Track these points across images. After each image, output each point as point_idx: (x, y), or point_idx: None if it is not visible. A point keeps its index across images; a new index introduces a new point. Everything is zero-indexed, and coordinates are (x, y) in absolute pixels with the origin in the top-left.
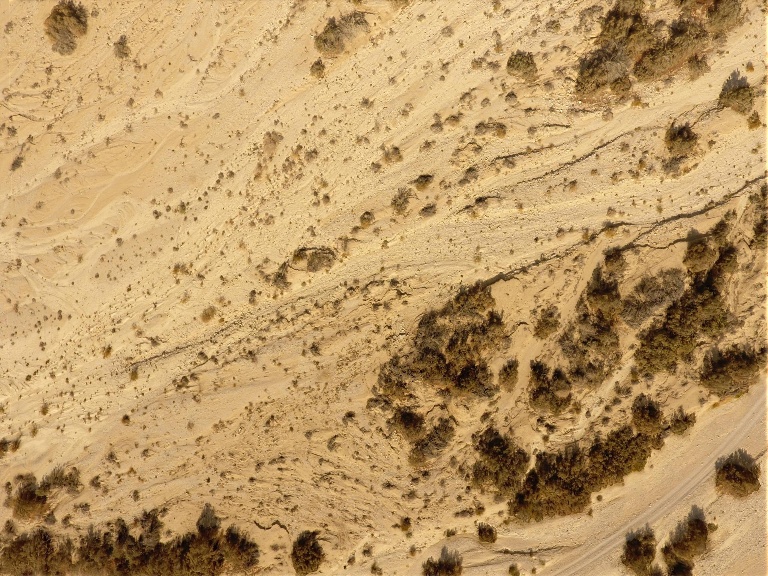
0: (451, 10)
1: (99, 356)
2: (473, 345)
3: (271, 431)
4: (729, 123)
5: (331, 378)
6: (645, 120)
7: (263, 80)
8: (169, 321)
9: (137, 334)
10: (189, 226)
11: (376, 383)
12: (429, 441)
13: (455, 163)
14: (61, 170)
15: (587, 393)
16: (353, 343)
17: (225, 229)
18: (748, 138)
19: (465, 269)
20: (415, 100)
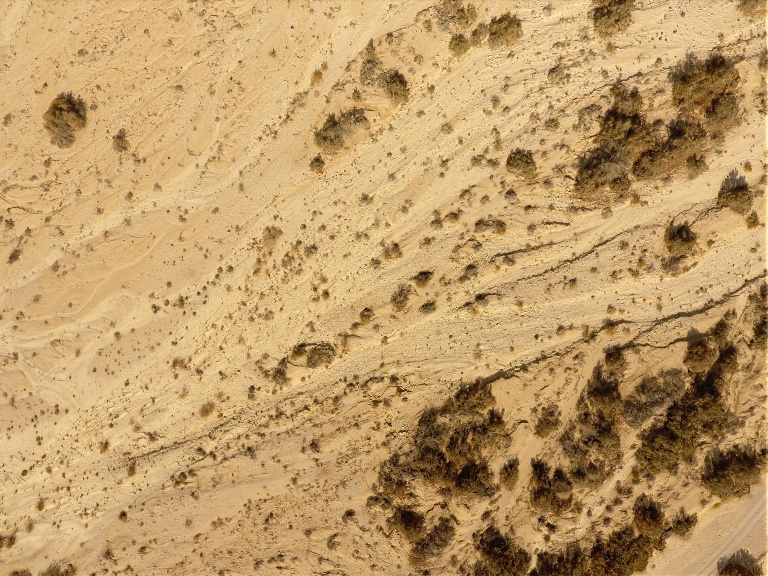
0: (450, 107)
1: (96, 451)
2: (474, 444)
3: (270, 529)
4: (728, 223)
5: (331, 475)
6: (644, 218)
7: (262, 175)
8: (167, 416)
9: (135, 429)
10: (188, 321)
11: (376, 481)
12: (430, 541)
13: (455, 260)
14: (59, 263)
15: (588, 492)
16: (353, 440)
17: (224, 324)
18: (747, 237)
19: (465, 366)
20: (415, 197)
